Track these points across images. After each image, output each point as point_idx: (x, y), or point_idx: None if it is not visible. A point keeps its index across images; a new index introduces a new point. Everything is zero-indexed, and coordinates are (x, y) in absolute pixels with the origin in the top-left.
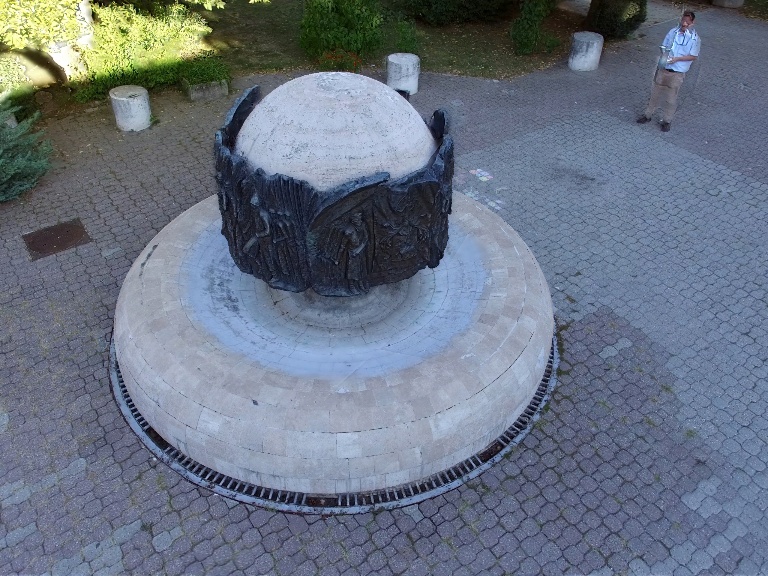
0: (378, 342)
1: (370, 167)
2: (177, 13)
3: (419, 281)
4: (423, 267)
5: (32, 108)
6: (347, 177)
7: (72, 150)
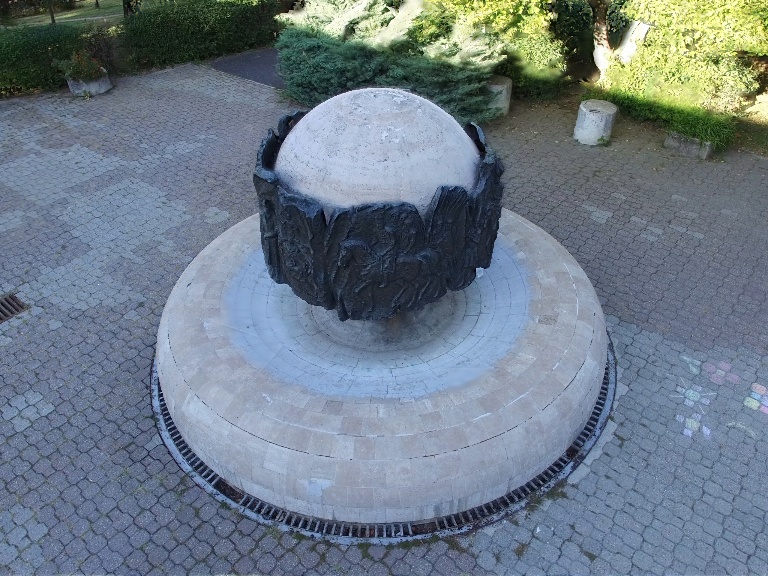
0: (298, 344)
1: (300, 173)
2: (728, 59)
3: (408, 355)
4: (325, 306)
5: (546, 90)
6: (286, 169)
7: (522, 130)
